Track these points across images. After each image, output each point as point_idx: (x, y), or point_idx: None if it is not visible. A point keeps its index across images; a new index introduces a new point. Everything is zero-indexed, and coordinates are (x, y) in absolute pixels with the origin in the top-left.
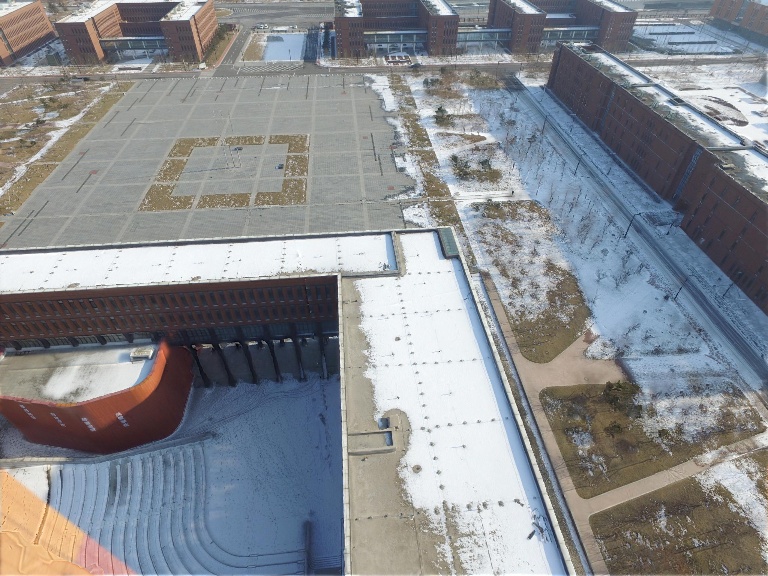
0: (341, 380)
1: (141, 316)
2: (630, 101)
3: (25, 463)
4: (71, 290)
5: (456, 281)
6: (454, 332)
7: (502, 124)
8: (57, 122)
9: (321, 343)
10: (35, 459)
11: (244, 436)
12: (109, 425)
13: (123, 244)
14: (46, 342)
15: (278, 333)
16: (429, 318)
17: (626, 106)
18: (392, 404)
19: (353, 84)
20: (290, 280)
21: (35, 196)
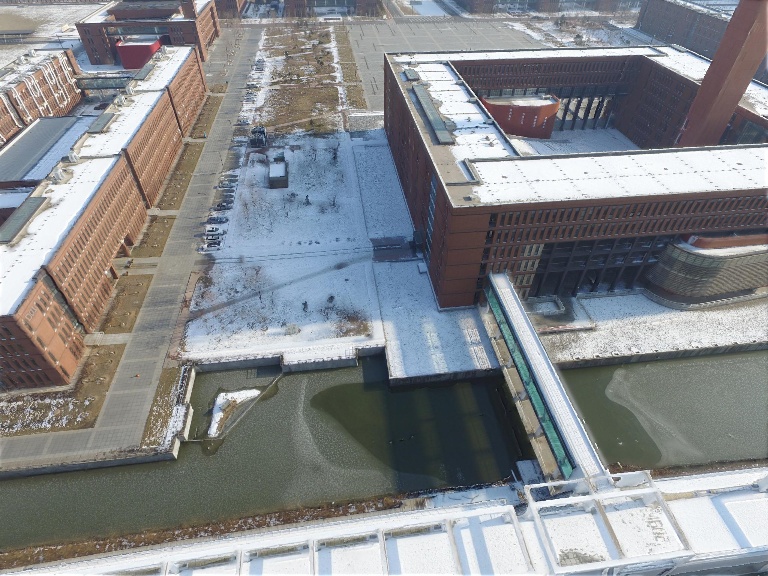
0: (676, 72)
1: (550, 77)
2: (713, 21)
3: (509, 137)
4: (534, 58)
5: (693, 57)
6: (705, 66)
7: (622, 43)
8: (323, 45)
9: (615, 101)
10: (514, 135)
11: (584, 142)
12: (540, 124)
13: (534, 49)
14: (501, 93)
15: (599, 93)
16: (692, 64)
17: (709, 25)
18: (699, 77)
19: (500, 27)
20: (622, 57)
21: (362, 75)
